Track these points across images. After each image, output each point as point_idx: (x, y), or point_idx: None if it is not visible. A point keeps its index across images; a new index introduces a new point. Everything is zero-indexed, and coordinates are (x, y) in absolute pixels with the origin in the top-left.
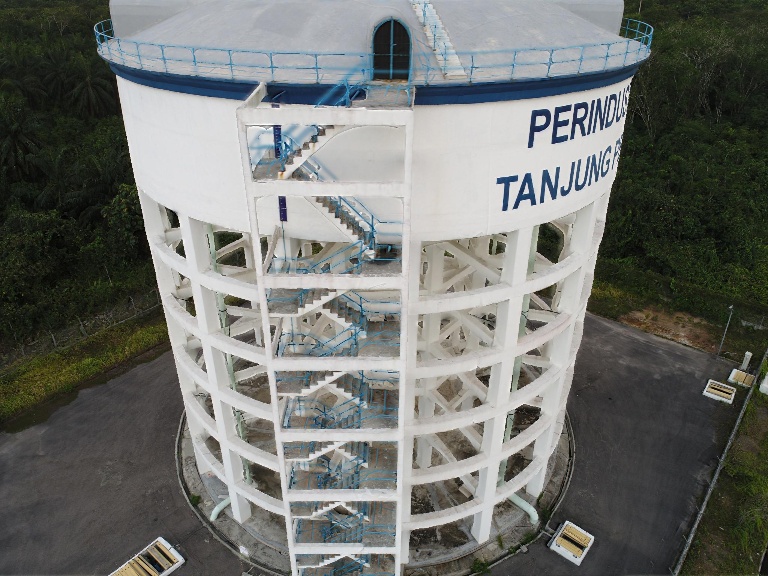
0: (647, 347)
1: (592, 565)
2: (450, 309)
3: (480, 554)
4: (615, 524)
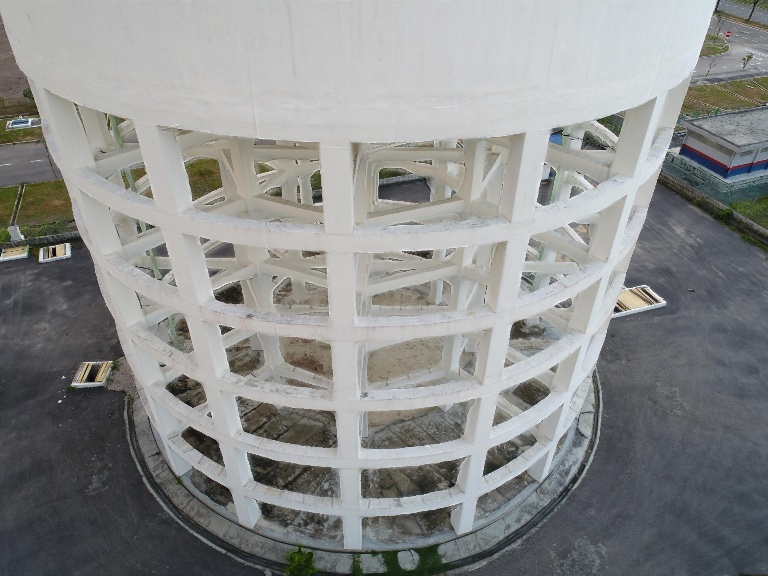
0: (7, 310)
1: None
2: None
3: None
4: None
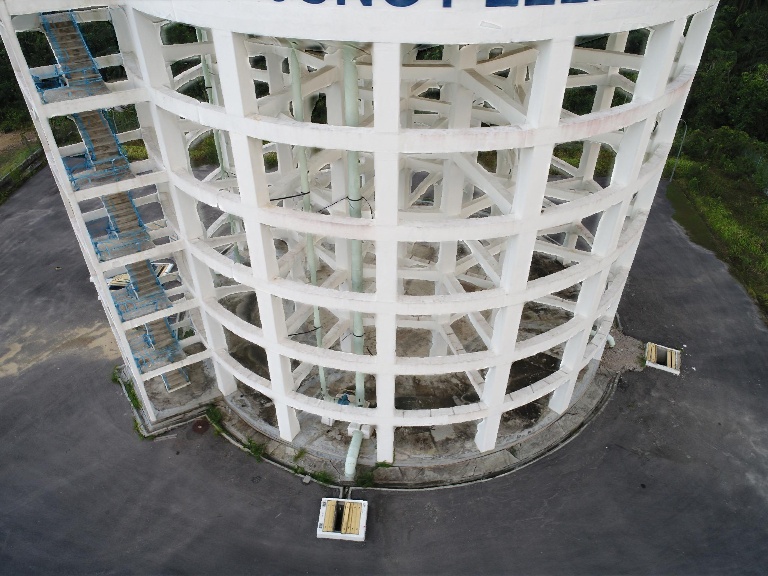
0: None
1: (327, 551)
2: (173, 111)
3: (275, 445)
4: (408, 557)
